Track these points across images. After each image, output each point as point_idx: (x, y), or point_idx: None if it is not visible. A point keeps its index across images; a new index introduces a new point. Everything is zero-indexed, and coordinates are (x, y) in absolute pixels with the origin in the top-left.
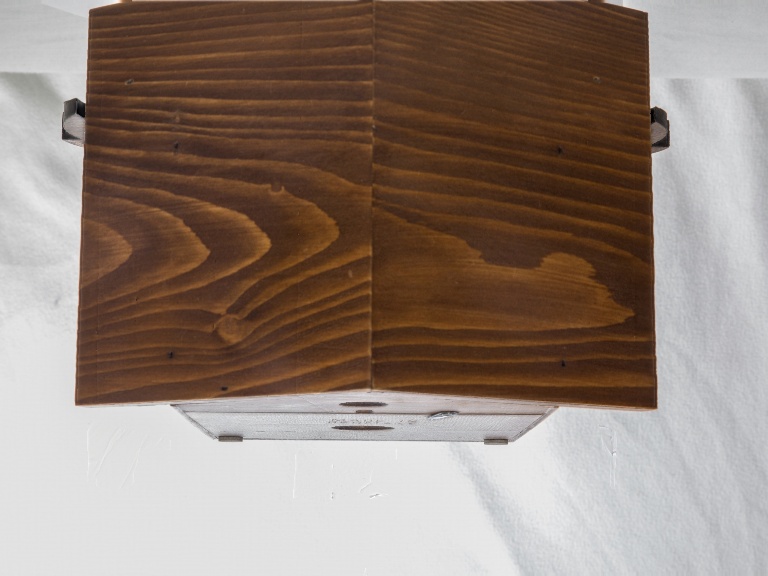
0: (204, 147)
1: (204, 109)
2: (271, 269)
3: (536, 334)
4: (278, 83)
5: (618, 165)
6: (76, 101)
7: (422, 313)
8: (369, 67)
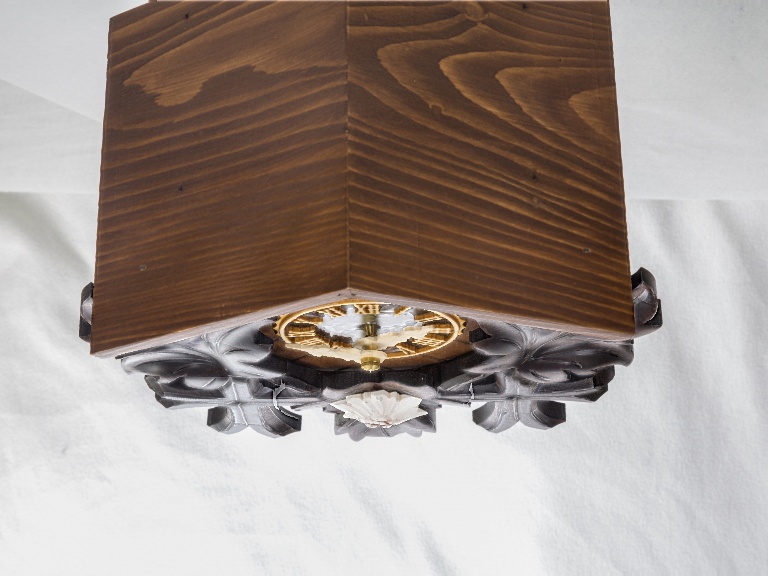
0: (508, 166)
1: (510, 200)
2: (438, 44)
3: (209, 28)
4: (439, 199)
5: (129, 200)
6: (643, 278)
7: (305, 1)
8: (352, 183)
